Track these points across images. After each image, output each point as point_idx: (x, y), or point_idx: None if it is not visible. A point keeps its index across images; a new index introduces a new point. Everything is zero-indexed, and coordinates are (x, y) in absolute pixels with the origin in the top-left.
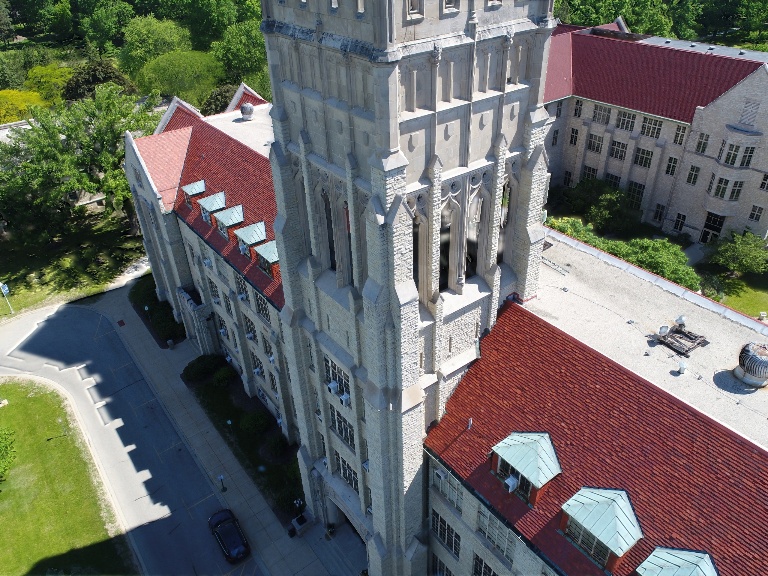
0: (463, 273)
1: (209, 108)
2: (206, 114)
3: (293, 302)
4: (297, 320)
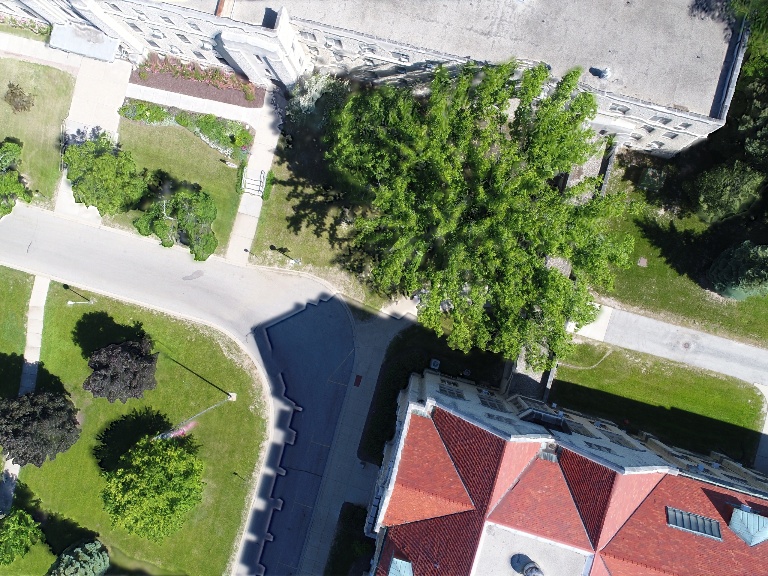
0: None
1: (759, 105)
2: (748, 100)
3: None
4: None
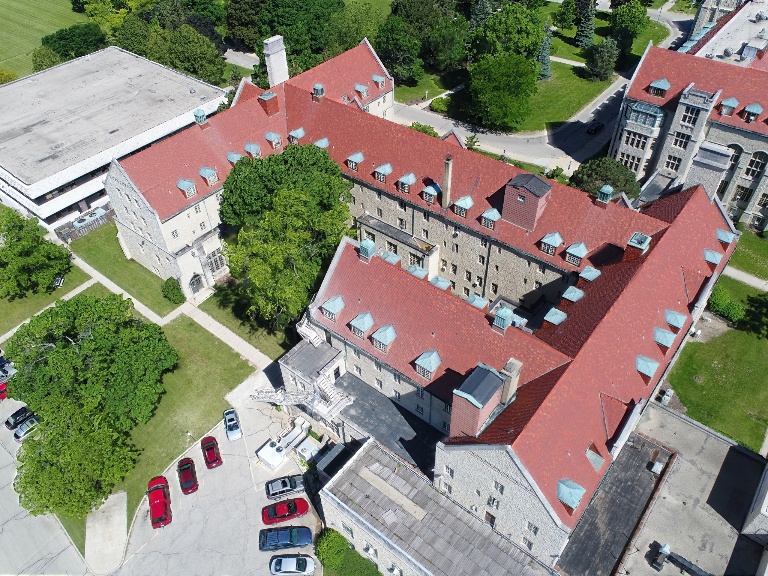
0: None
1: None
2: None
3: None
4: None
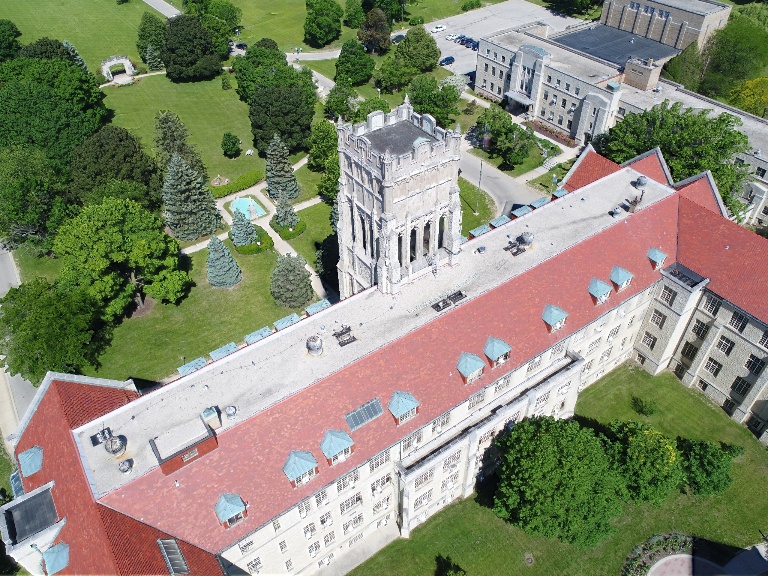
0: (368, 250)
1: None
2: None
3: None
4: None
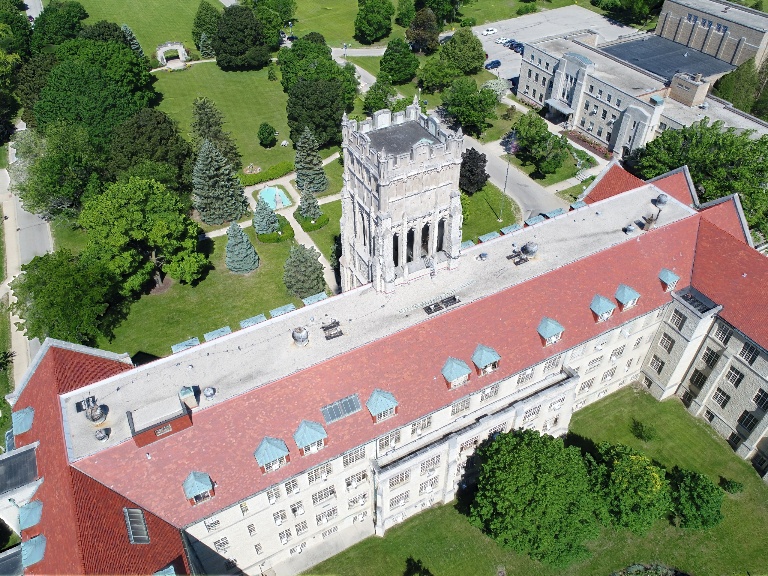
0: (367, 247)
1: None
2: None
3: None
4: None
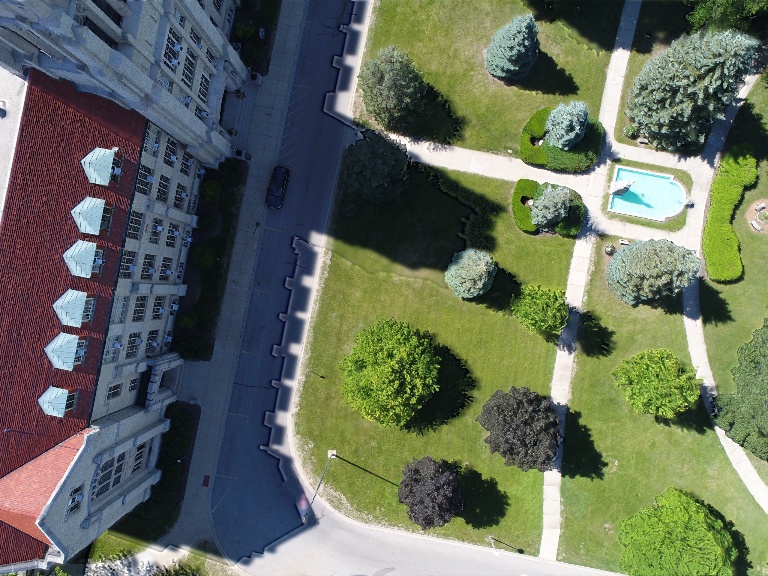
0: None
1: None
2: None
3: (149, 78)
4: (156, 81)
